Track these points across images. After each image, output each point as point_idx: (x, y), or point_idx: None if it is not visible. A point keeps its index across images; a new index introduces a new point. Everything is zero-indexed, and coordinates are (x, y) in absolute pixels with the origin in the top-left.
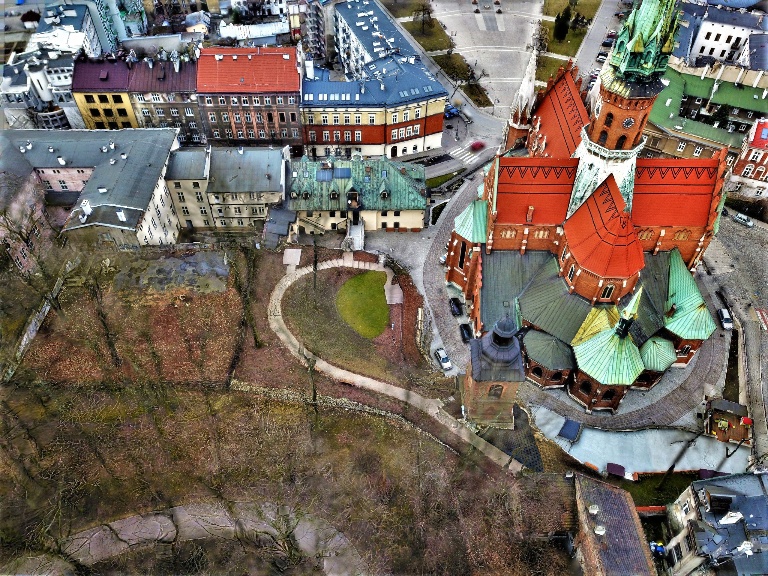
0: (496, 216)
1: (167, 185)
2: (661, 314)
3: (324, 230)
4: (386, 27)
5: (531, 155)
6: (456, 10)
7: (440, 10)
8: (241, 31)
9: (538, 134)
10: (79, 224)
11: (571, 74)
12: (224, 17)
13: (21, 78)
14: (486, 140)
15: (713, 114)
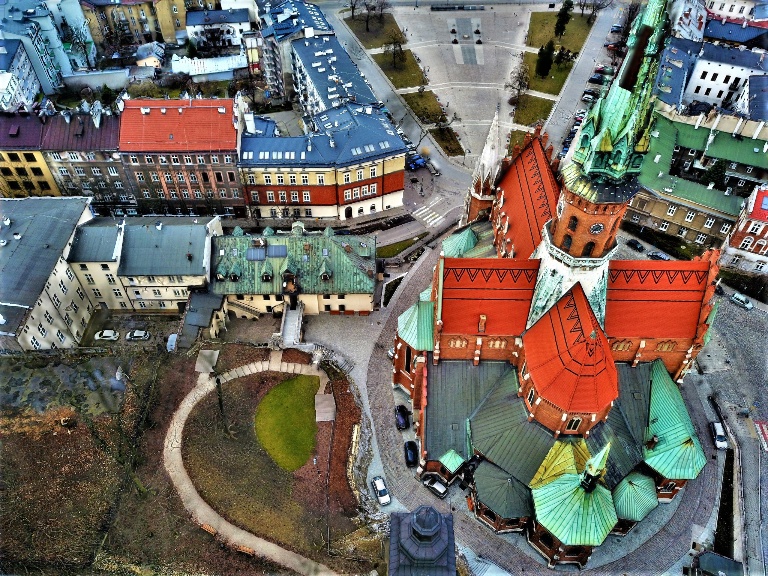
0: (441, 326)
1: (71, 267)
2: (640, 444)
3: (259, 313)
4: (345, 68)
5: (495, 231)
6: (432, 40)
7: (415, 40)
8: (195, 66)
9: (501, 211)
10: None
11: (540, 141)
12: (181, 48)
13: None
14: (454, 197)
15: (708, 170)
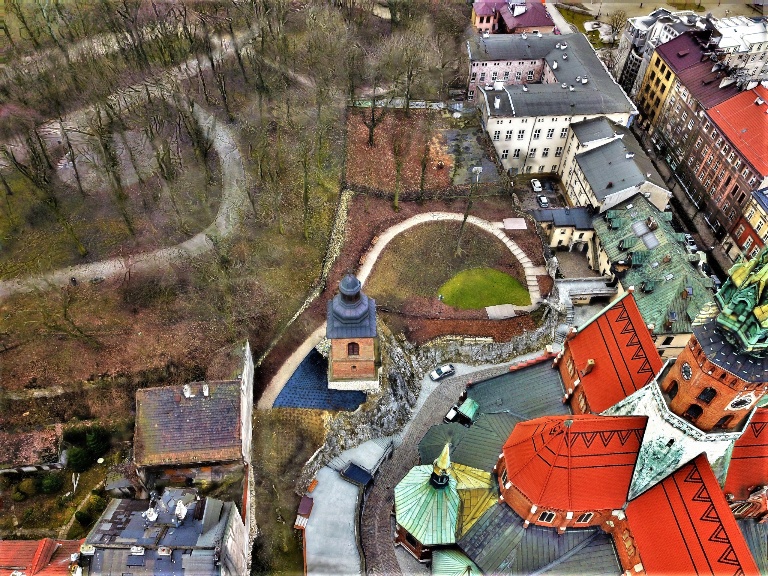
0: (573, 335)
1: (570, 131)
2: None
3: (598, 269)
4: None
5: None
6: None
7: None
8: None
9: None
10: (483, 88)
11: None
12: None
13: (653, 21)
14: None
15: None
